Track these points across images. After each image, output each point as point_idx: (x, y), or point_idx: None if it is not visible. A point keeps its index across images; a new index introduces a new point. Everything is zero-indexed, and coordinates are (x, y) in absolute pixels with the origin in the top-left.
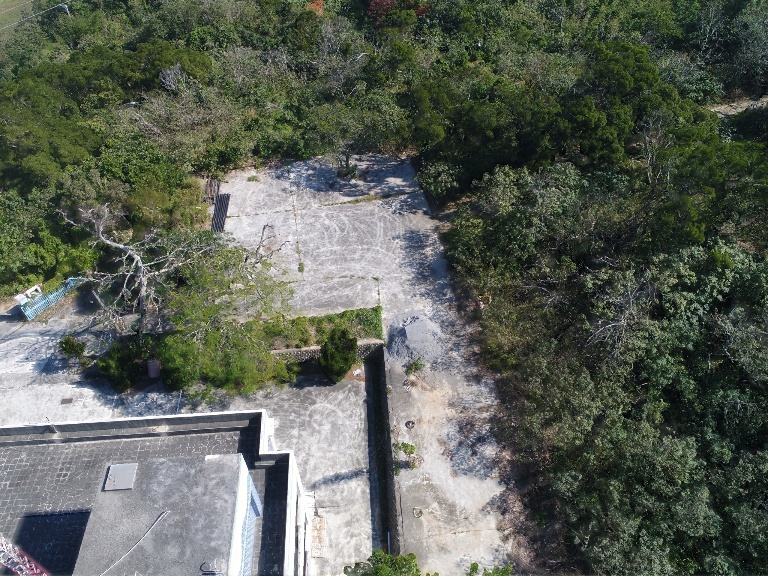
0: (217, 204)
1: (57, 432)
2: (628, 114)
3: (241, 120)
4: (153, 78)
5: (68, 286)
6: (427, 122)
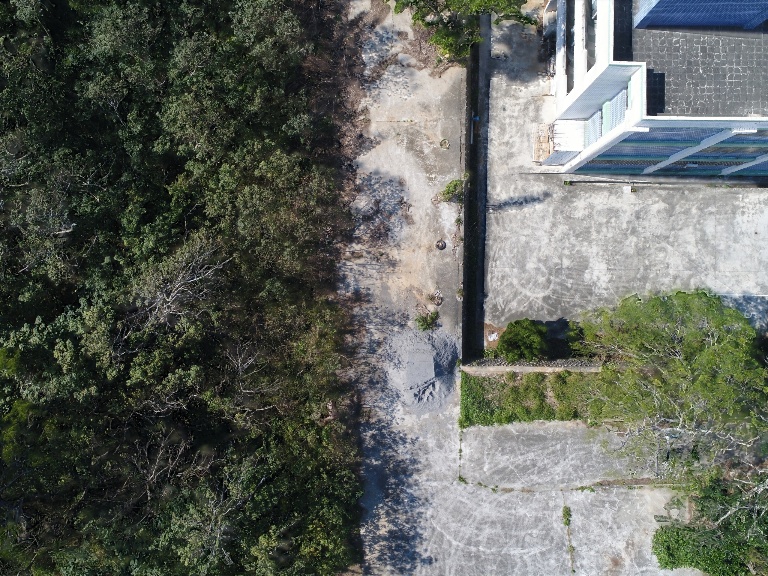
0: None
1: None
2: None
3: None
4: None
5: None
6: None
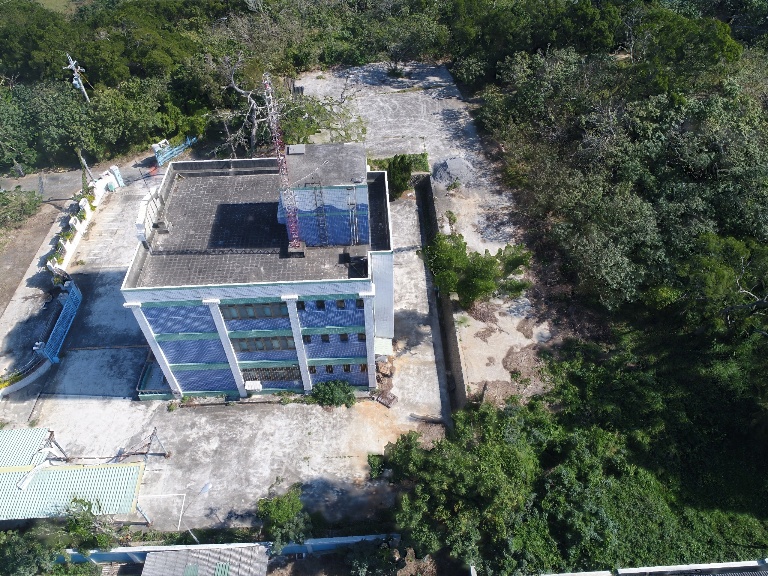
0: (294, 93)
1: (232, 168)
2: (617, 13)
3: (309, 35)
4: (233, 7)
5: (186, 144)
6: (462, 24)
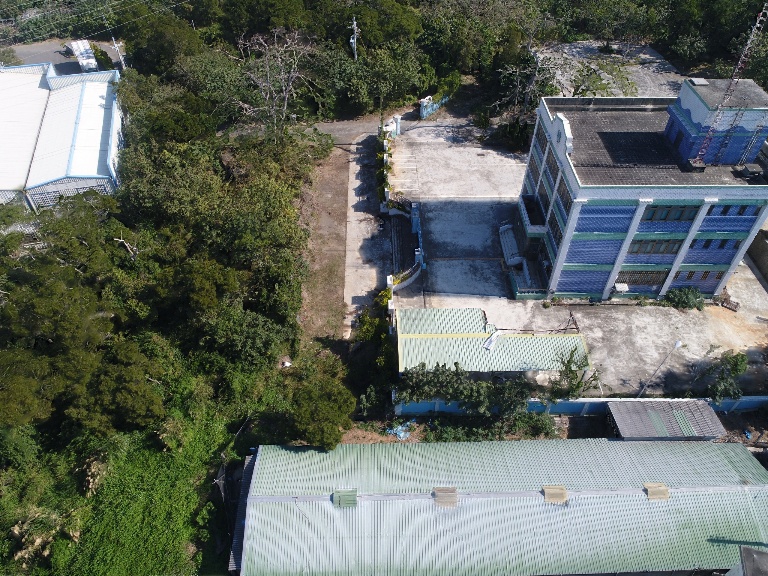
0: None
1: (591, 104)
2: None
3: None
4: None
5: (442, 102)
6: (687, 6)
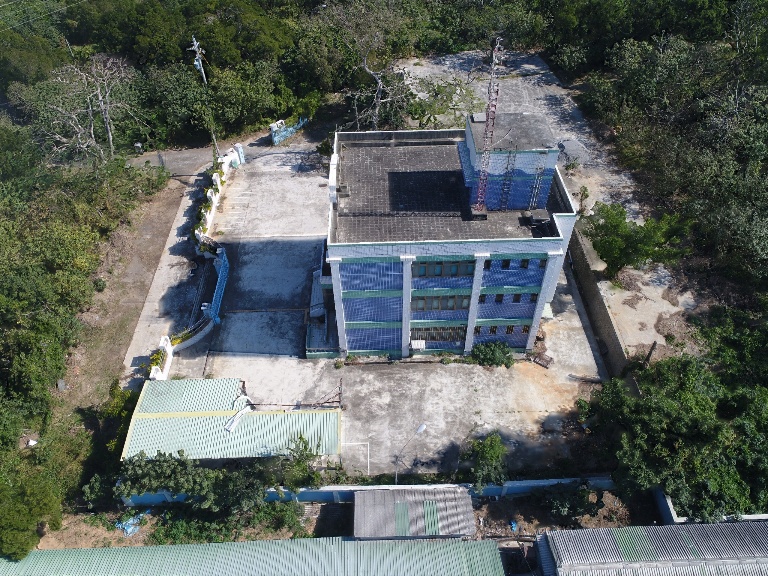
0: None
1: (393, 139)
2: (723, 3)
3: None
4: None
5: (299, 125)
6: (565, 13)
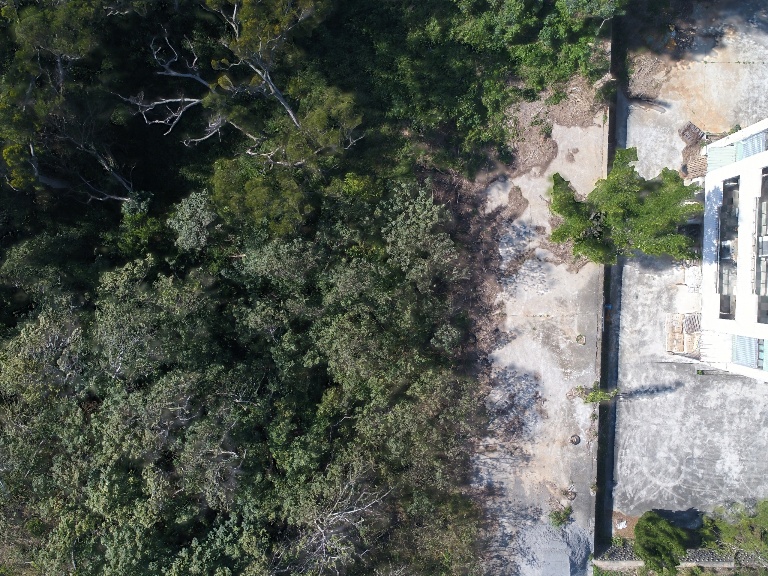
0: None
1: None
2: None
3: None
4: None
5: None
6: None
